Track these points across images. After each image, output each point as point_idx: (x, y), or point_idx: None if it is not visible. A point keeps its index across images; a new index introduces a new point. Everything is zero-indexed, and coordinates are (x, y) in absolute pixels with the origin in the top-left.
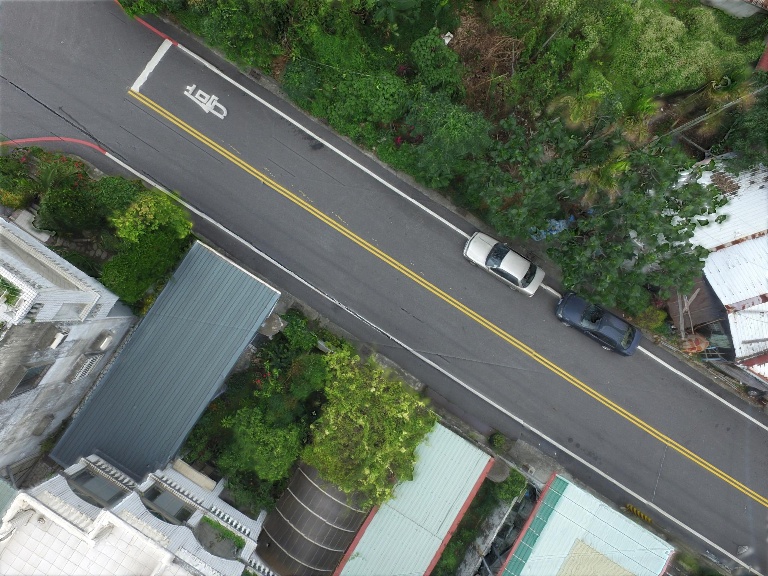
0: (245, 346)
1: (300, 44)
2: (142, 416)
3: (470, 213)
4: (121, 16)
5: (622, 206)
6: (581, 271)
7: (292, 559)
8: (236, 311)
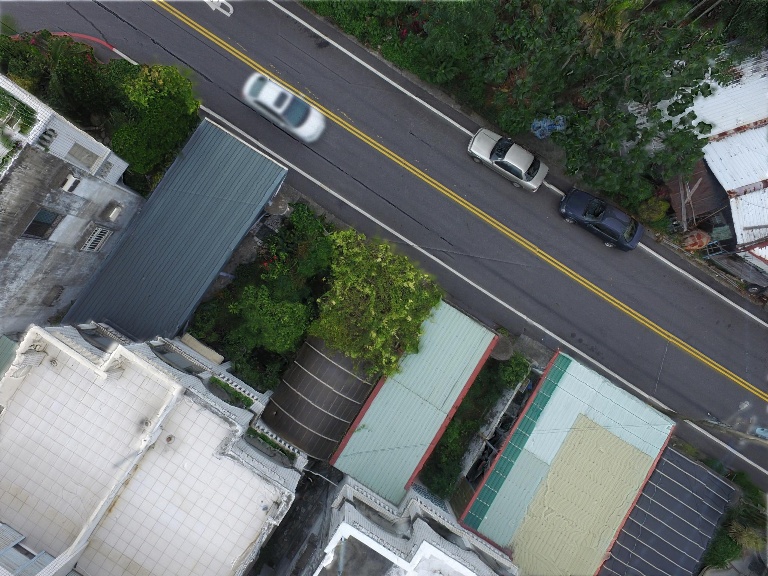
0: (253, 220)
1: None
2: (151, 288)
3: (474, 112)
4: None
5: (626, 68)
6: (585, 153)
7: (299, 425)
8: (244, 186)
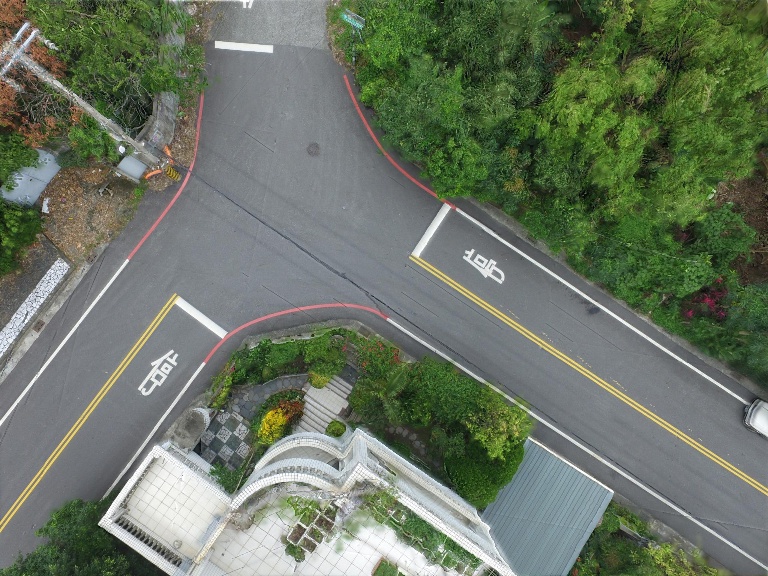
0: (582, 547)
1: (598, 221)
2: None
3: (745, 377)
4: (400, 180)
5: None
6: None
7: None
8: (570, 510)
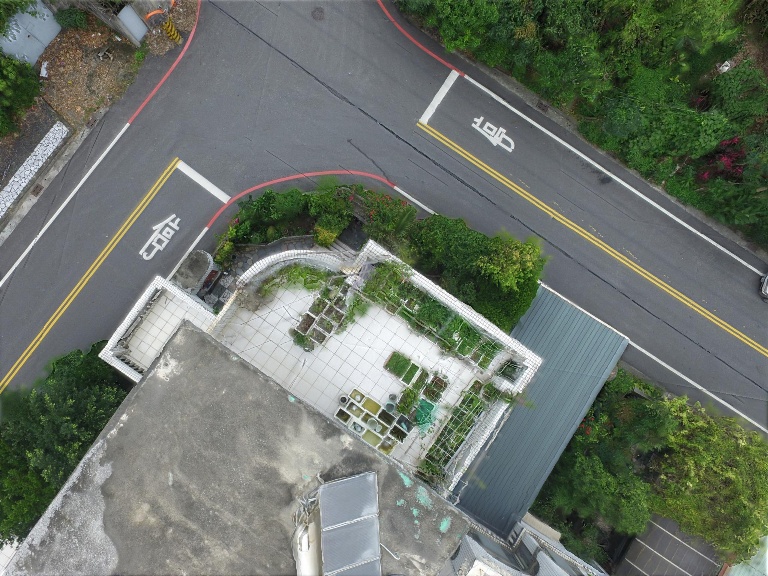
0: (597, 394)
1: (611, 77)
2: (494, 466)
3: (761, 249)
4: (407, 46)
5: None
6: None
7: None
8: (585, 357)
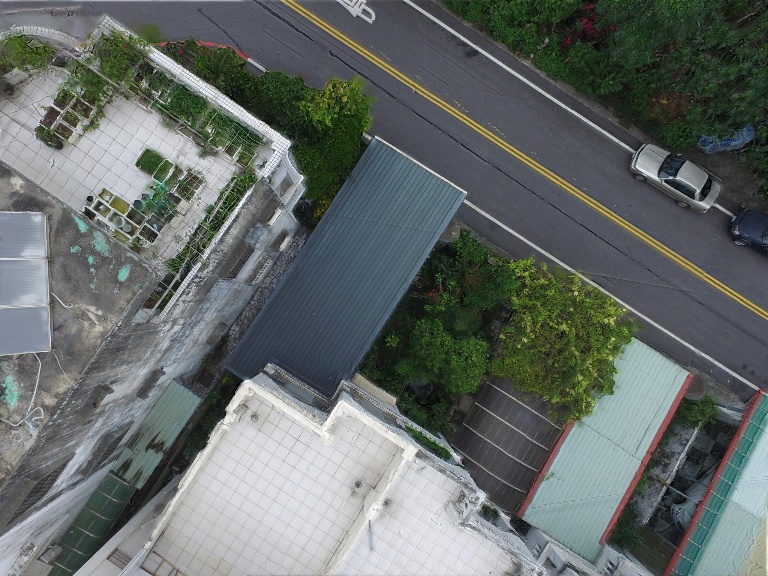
0: (431, 249)
1: None
2: (321, 324)
3: (634, 126)
4: None
5: None
6: None
7: (491, 476)
8: (420, 212)
